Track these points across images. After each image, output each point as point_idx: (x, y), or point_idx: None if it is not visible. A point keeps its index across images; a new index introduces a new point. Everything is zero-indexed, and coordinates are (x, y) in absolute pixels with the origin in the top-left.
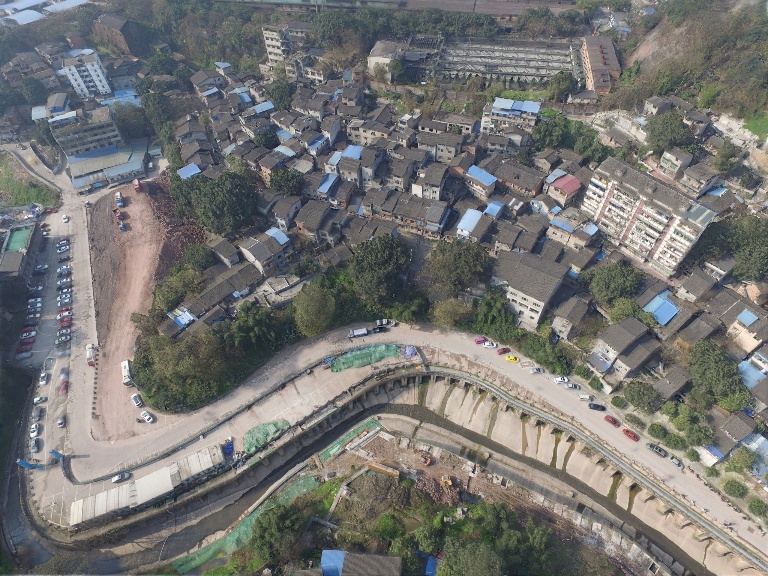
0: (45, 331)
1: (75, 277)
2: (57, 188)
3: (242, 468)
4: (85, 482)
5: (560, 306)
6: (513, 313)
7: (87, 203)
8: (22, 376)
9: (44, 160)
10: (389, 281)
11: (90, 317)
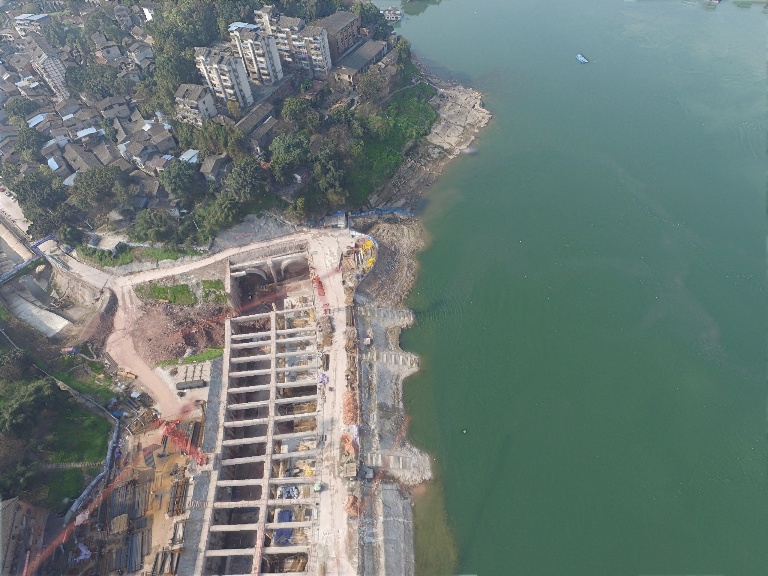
0: None
1: None
2: None
3: None
4: None
5: None
6: None
7: None
8: None
9: None
10: None
11: None
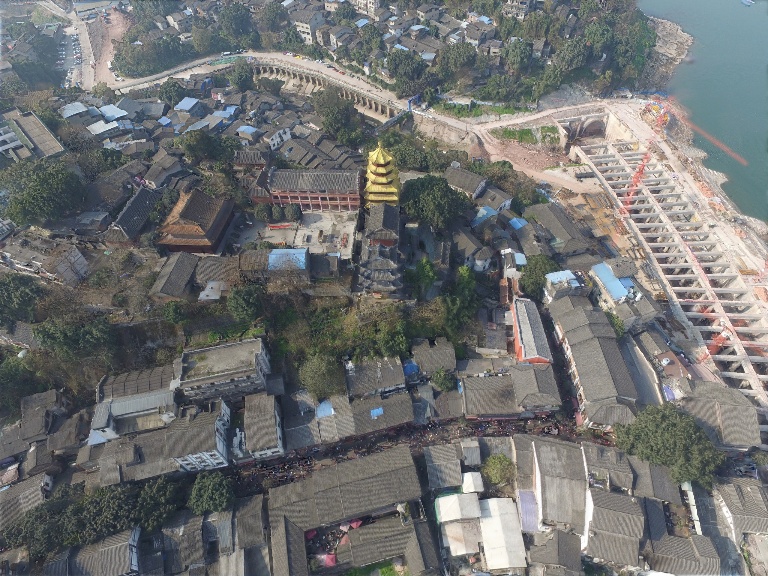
0: (68, 61)
1: (82, 46)
2: (69, 18)
3: None
4: None
5: None
6: (301, 39)
7: (86, 22)
8: (58, 78)
9: (60, 7)
10: (237, 20)
11: (91, 56)
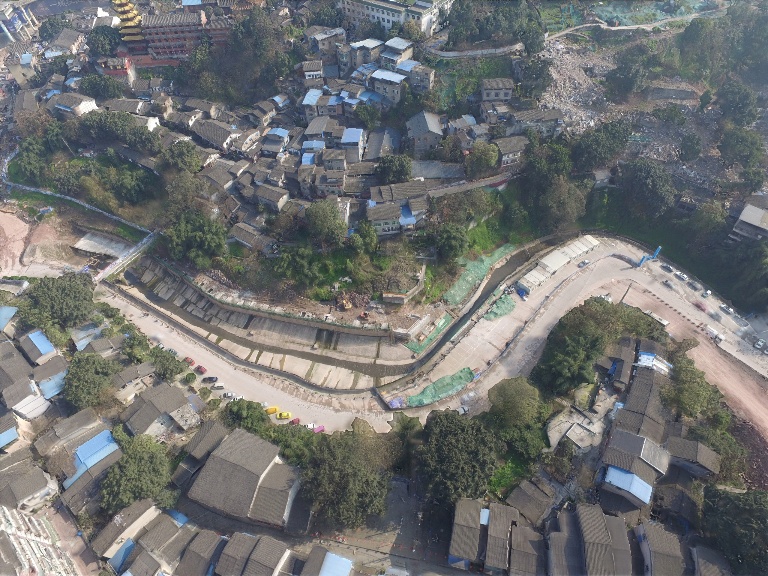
0: None
1: None
2: None
3: (504, 287)
4: (606, 256)
5: (219, 443)
6: None
7: None
8: None
9: None
10: None
11: (767, 373)
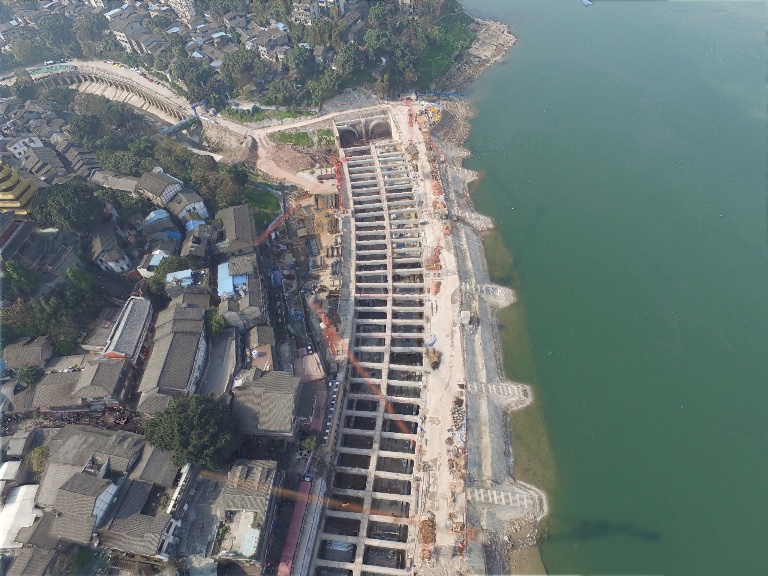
0: None
1: None
2: None
3: None
4: None
5: None
6: (122, 47)
7: None
8: None
9: None
10: (55, 30)
11: None
